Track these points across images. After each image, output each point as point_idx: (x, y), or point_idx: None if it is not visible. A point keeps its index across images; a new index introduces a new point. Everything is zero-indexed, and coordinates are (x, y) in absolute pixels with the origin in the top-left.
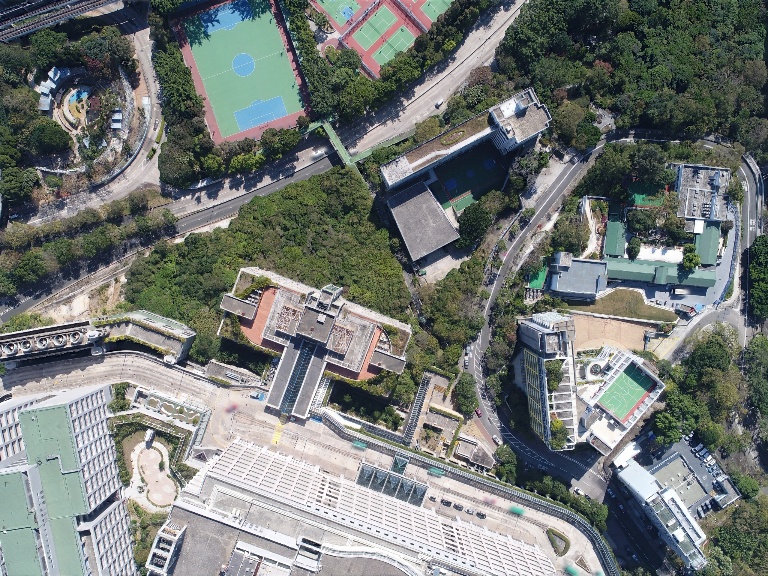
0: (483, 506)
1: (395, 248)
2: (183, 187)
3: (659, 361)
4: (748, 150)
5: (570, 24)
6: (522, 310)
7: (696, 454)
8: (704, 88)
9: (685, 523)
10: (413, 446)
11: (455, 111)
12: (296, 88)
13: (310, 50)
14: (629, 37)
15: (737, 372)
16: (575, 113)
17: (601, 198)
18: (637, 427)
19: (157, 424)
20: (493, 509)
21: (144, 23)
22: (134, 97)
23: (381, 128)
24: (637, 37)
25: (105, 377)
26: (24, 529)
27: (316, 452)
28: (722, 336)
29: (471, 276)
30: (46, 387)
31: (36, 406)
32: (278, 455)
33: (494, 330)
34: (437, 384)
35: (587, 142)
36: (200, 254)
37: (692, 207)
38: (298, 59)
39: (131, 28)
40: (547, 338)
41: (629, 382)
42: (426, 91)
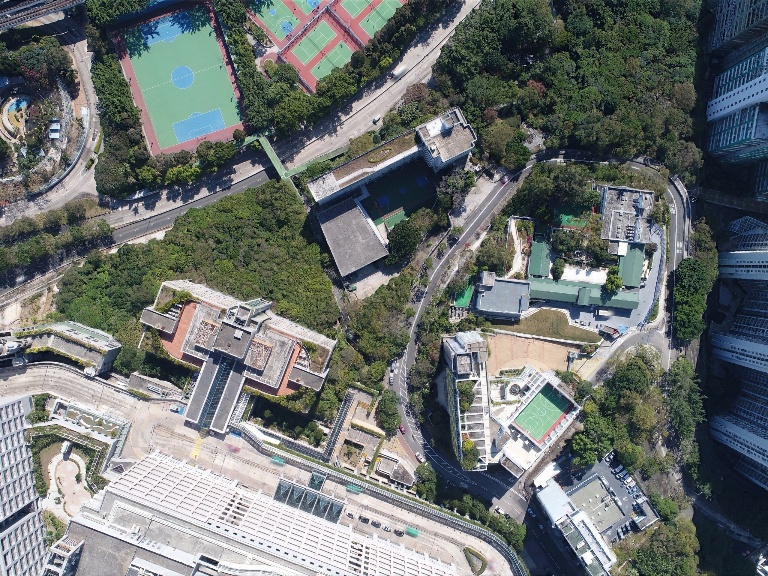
0: (401, 524)
1: (325, 263)
2: (120, 198)
3: (580, 382)
4: (676, 173)
5: (504, 43)
6: (447, 328)
7: (616, 475)
8: (632, 110)
9: (595, 546)
10: (333, 462)
11: (390, 127)
12: (234, 101)
13: (247, 64)
14: (564, 57)
15: (659, 394)
16: (503, 133)
17: (527, 218)
18: (558, 447)
19: (74, 436)
20: (411, 527)
21: (84, 34)
22: (73, 107)
23: (318, 143)
24: (572, 57)
25: (27, 388)
26: None
27: (235, 466)
28: (644, 358)
29: (397, 293)
30: None
31: None
32: (196, 469)
33: (420, 347)
34: (361, 400)
35: (516, 162)
36: (131, 265)
37: (616, 229)
38: (236, 73)
39: (71, 38)
40: (459, 359)
41: (546, 403)
42: (364, 107)
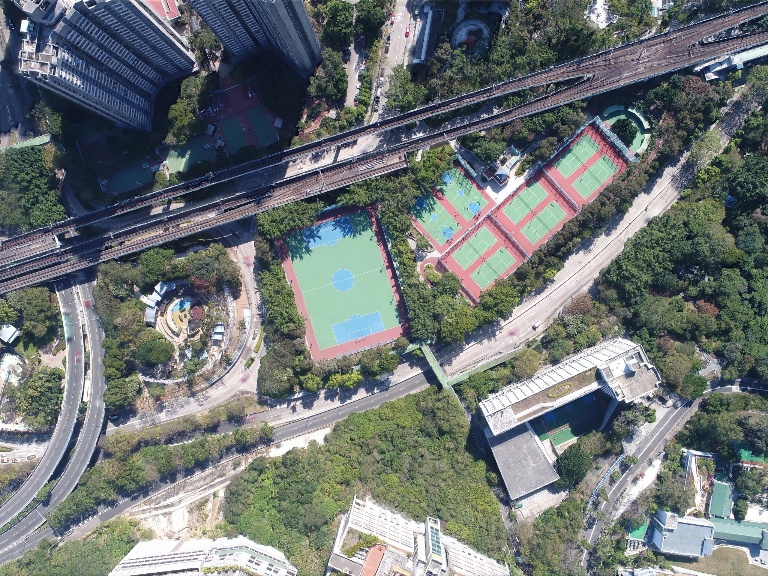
0: None
1: (493, 483)
2: (280, 399)
3: None
4: None
5: (675, 263)
6: (622, 561)
7: None
8: None
9: None
10: None
11: (555, 341)
12: (394, 304)
13: (411, 273)
14: (735, 275)
15: None
16: (683, 367)
17: (708, 456)
18: None
19: None
20: None
21: (247, 237)
22: (235, 308)
23: (477, 346)
24: (742, 274)
25: None
26: None
27: None
28: None
29: (572, 524)
30: None
31: None
32: None
33: (592, 575)
34: None
35: (693, 392)
36: (299, 478)
37: None
38: (398, 279)
39: (235, 241)
40: None
41: None
42: (523, 312)
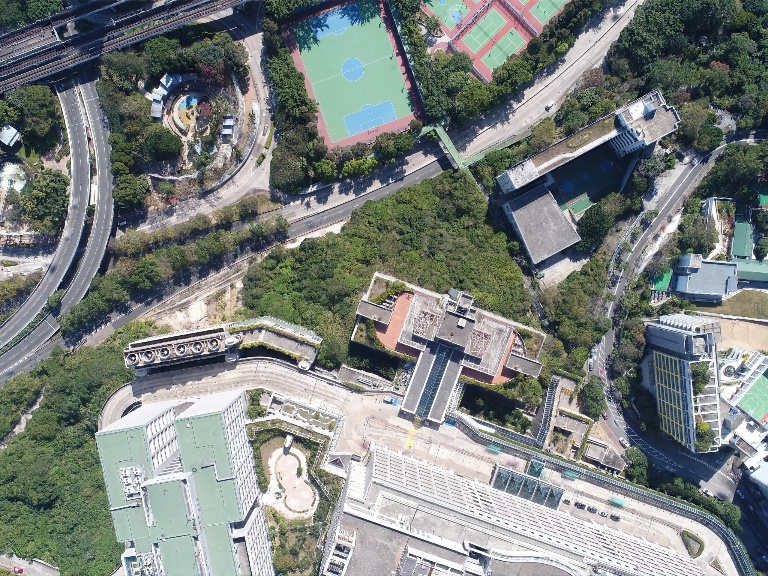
0: (617, 509)
1: (515, 251)
2: (294, 192)
3: None
4: None
5: (686, 25)
6: (648, 312)
7: None
8: None
9: None
10: (545, 449)
11: (569, 113)
12: (405, 92)
13: (422, 54)
14: (744, 37)
15: None
16: (699, 114)
17: (728, 199)
18: None
19: (296, 430)
20: (627, 511)
21: (253, 29)
22: (243, 103)
23: (491, 131)
24: (751, 37)
25: (237, 383)
26: (183, 537)
27: (450, 456)
28: None
29: (596, 278)
30: (177, 394)
31: (188, 414)
32: (414, 460)
33: (618, 332)
34: (564, 387)
35: (710, 143)
36: (318, 259)
37: None
38: (409, 63)
39: (240, 34)
40: (693, 340)
41: (766, 383)
42: (536, 94)
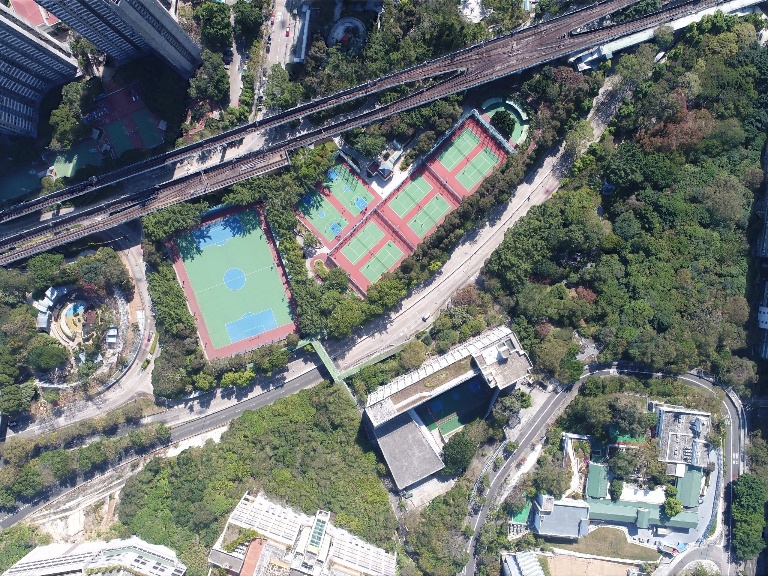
0: None
1: (381, 474)
2: (176, 399)
3: None
4: (730, 385)
5: (553, 251)
6: (506, 545)
7: None
8: (685, 328)
9: None
10: None
11: (441, 331)
12: (286, 301)
13: (299, 270)
14: (612, 260)
15: None
16: (557, 352)
17: (583, 438)
18: None
19: None
20: None
21: (138, 239)
22: (129, 310)
23: (369, 340)
24: (620, 260)
25: None
26: None
27: None
28: None
29: (455, 511)
30: None
31: None
32: None
33: (479, 561)
34: None
35: (570, 377)
36: (191, 477)
37: (673, 451)
38: None
39: (126, 244)
40: None
41: None
42: (413, 304)
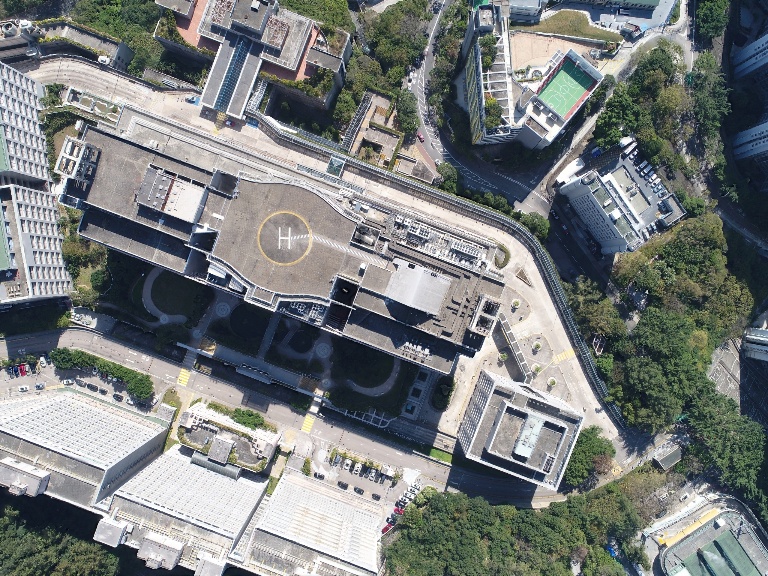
0: None
1: None
2: None
3: None
4: None
5: None
6: None
7: (641, 173)
8: None
9: (623, 209)
10: None
11: None
12: None
13: None
14: None
15: (682, 91)
16: None
17: None
18: (581, 147)
19: (88, 116)
20: None
21: None
22: None
23: None
24: None
25: None
26: None
27: None
28: None
29: None
30: None
31: None
32: None
33: None
34: (378, 105)
35: None
36: None
37: None
38: None
39: None
40: (481, 12)
41: (569, 80)
42: None
